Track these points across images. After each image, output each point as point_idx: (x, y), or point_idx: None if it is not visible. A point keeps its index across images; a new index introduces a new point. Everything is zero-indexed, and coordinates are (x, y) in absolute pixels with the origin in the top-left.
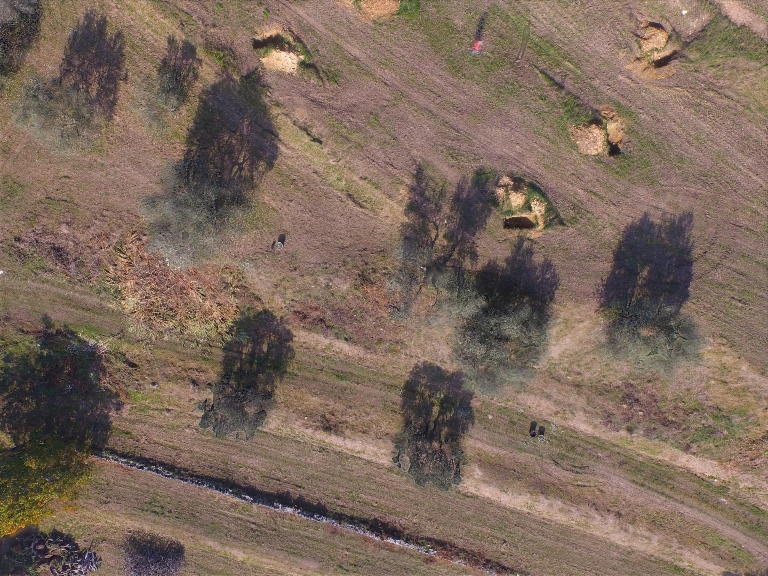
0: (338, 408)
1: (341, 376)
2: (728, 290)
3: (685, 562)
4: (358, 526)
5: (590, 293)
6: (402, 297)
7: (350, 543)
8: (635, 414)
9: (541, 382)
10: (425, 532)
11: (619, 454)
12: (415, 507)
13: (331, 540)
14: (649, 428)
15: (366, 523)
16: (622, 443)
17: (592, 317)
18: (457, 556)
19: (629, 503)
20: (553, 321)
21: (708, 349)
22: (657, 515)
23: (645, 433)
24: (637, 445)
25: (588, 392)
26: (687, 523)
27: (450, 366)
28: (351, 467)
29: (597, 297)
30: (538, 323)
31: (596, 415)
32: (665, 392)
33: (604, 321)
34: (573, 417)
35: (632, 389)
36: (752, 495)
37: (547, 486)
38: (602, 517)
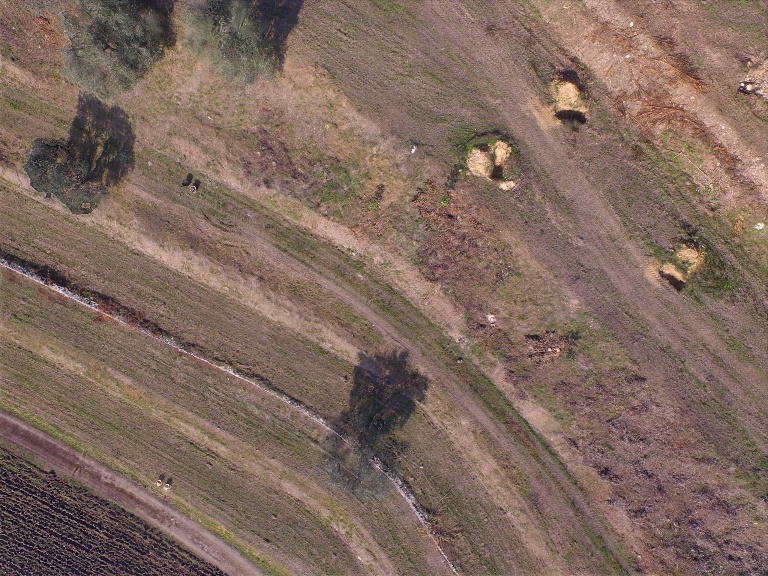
0: (10, 138)
1: (15, 105)
2: (335, 21)
3: (327, 342)
4: (27, 269)
5: (207, 9)
6: (48, 5)
7: (27, 293)
8: (269, 164)
9: (185, 121)
10: (92, 285)
11: (267, 217)
12: (85, 259)
13: (9, 287)
14: (282, 181)
15: (36, 268)
16: (269, 204)
17: (212, 38)
18: (117, 311)
19: (272, 269)
20: (180, 42)
21: (312, 80)
22: (298, 285)
23: (281, 188)
24: (281, 207)
25: (227, 136)
26: (324, 295)
27: (108, 99)
28: (29, 210)
29: (213, 14)
30: (136, 17)
31: (237, 164)
32: (293, 140)
33: (225, 45)
34: (223, 170)
35: (266, 136)
36: (386, 273)
37: (197, 242)
38: (246, 280)
